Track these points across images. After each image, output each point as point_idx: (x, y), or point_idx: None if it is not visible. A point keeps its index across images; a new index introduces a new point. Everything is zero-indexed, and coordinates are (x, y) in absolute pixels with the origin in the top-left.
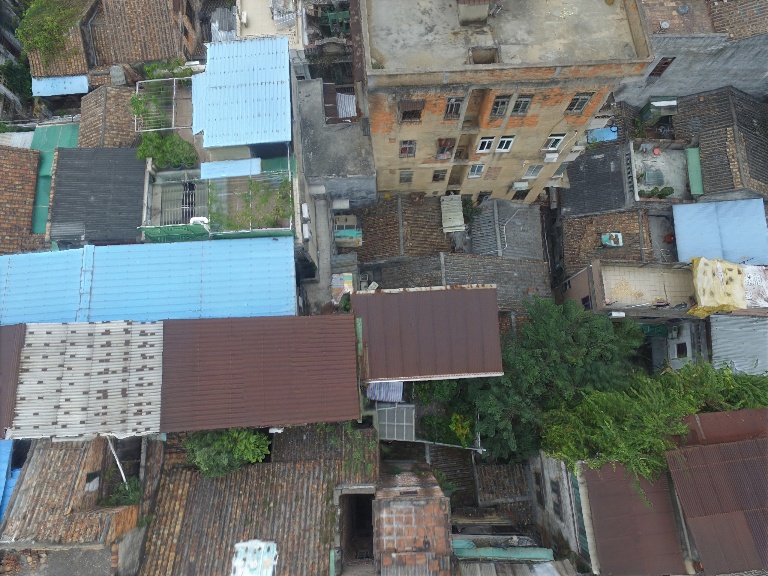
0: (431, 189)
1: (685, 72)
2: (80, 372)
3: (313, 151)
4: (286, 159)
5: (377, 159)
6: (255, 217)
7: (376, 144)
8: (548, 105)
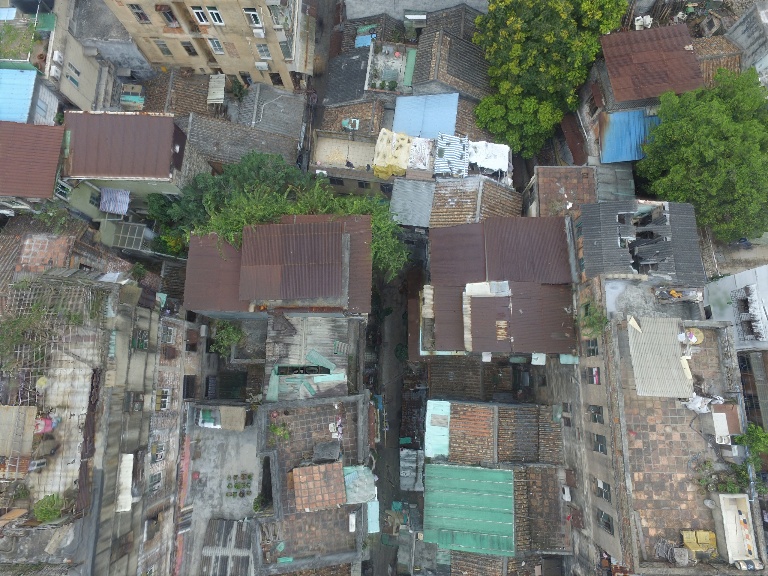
0: (195, 65)
1: None
2: None
3: (87, 19)
4: (47, 15)
5: (124, 24)
6: (2, 50)
7: (110, 6)
8: None
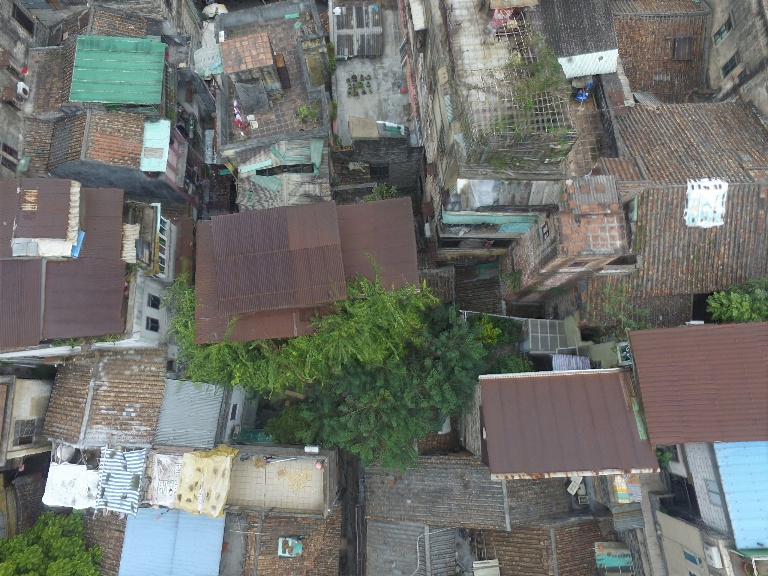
0: None
1: None
2: None
3: None
4: None
5: None
6: None
7: None
8: None
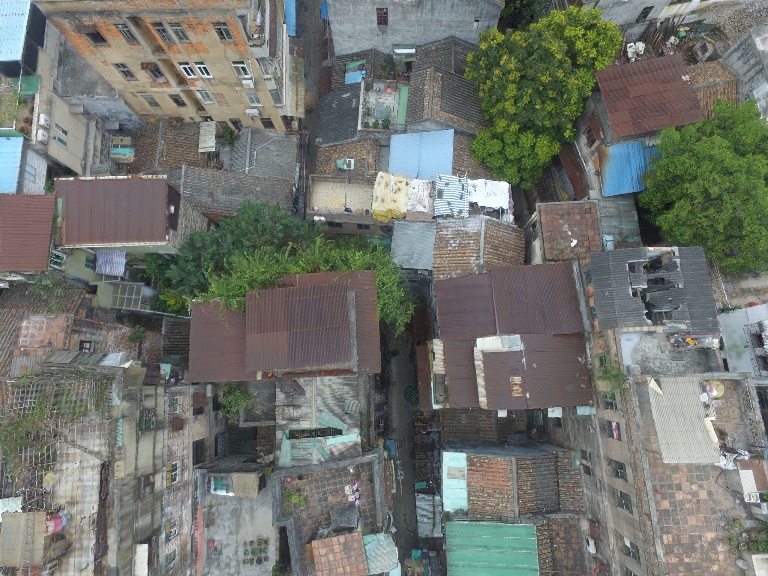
0: (184, 114)
1: (405, 22)
2: None
3: (71, 76)
4: (30, 78)
5: (109, 81)
6: None
7: (95, 66)
8: (200, 33)
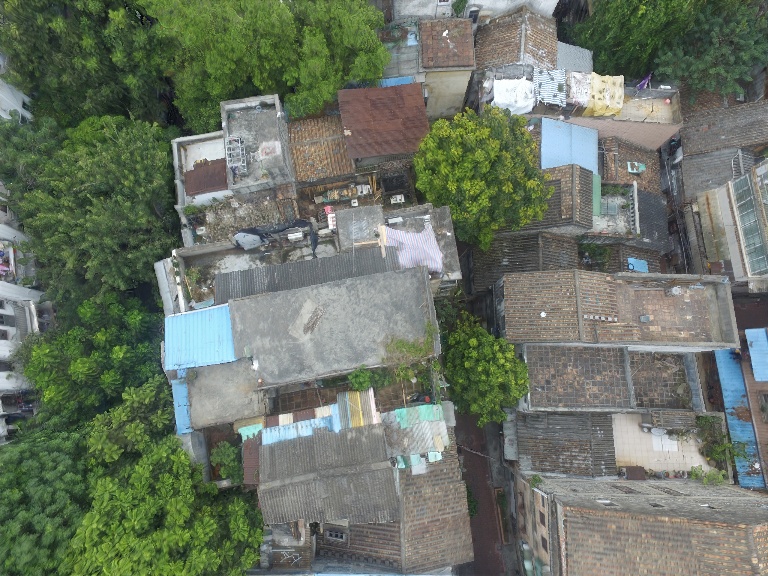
0: None
1: None
2: None
3: None
4: None
5: None
6: None
7: None
8: None
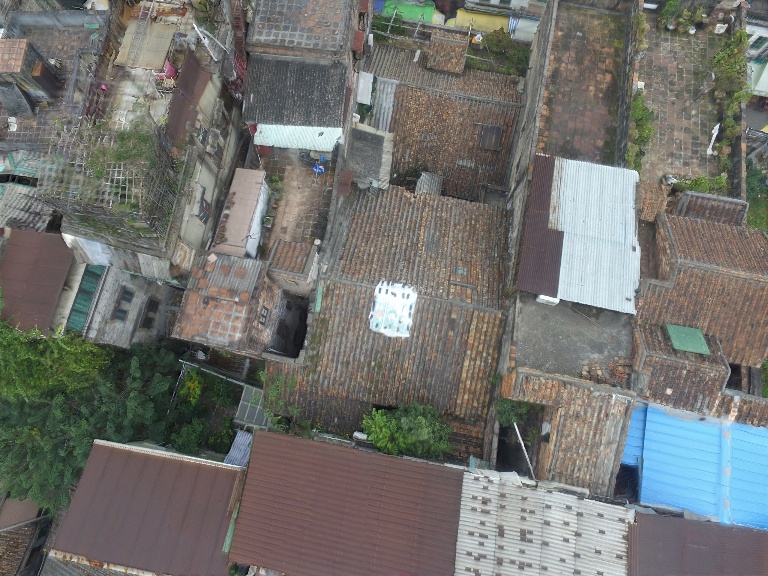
0: None
1: None
2: (553, 574)
3: None
4: None
5: None
6: None
7: None
8: None
